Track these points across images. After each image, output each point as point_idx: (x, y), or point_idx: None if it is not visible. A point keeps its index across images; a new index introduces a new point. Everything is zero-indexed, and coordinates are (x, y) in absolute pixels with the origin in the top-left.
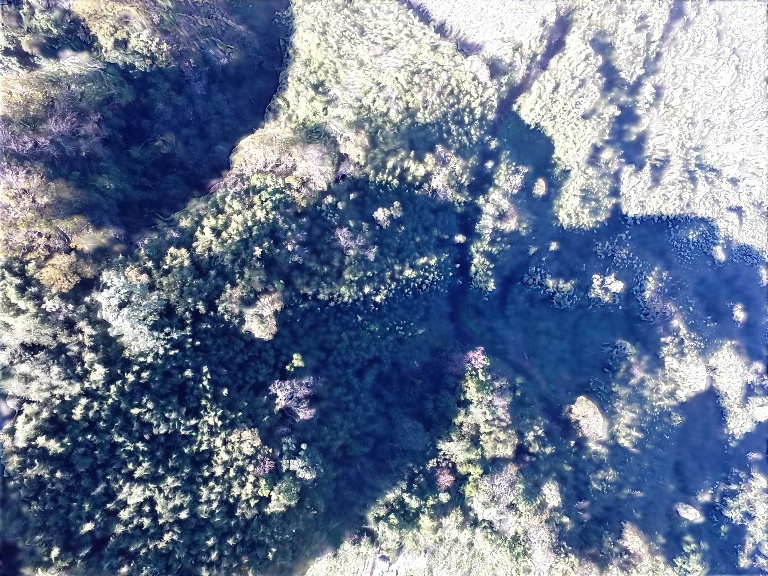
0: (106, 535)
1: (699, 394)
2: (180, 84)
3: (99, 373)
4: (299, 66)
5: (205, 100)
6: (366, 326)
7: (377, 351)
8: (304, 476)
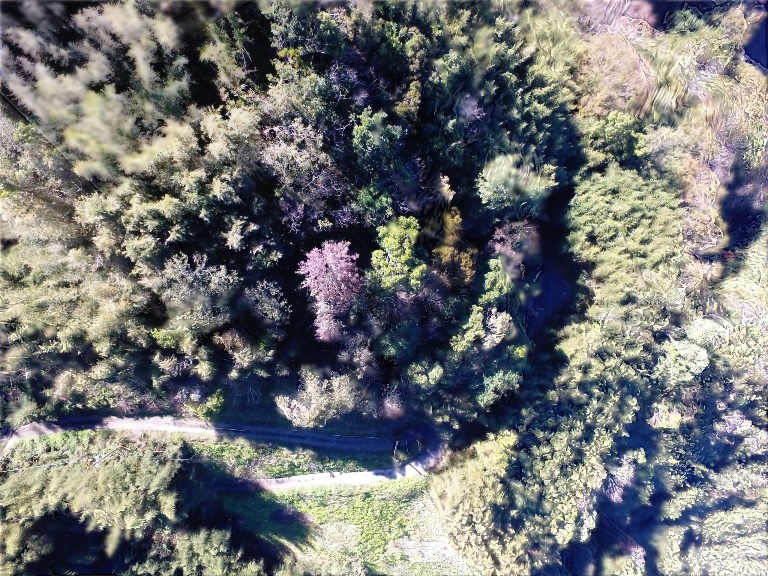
0: (526, 444)
1: None
2: (734, 186)
3: (636, 351)
4: None
5: (727, 210)
6: (651, 468)
7: (632, 487)
8: (583, 535)
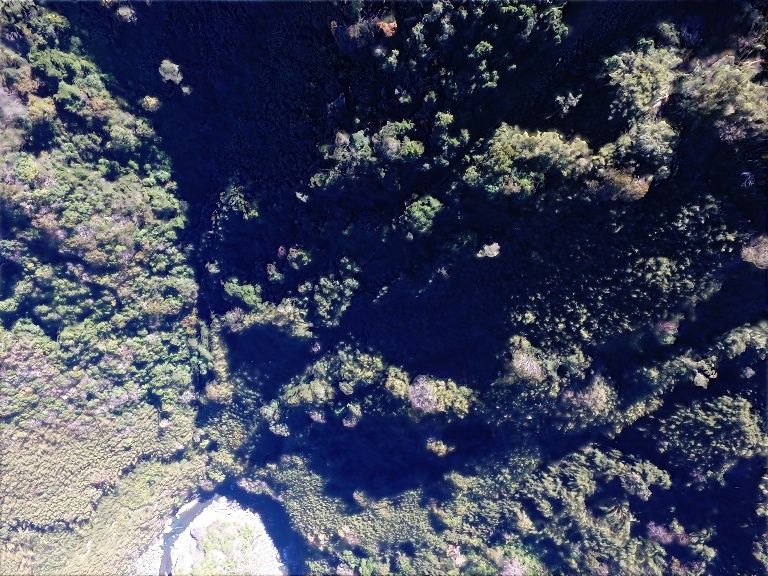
0: None
1: (422, 361)
2: None
3: None
4: None
5: None
6: None
7: None
8: None
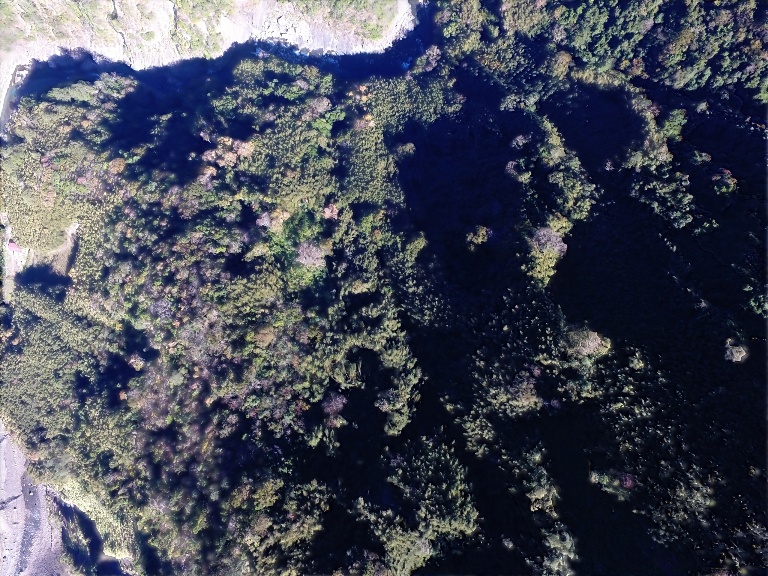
0: None
1: (568, 256)
2: None
3: None
4: None
5: None
6: None
7: None
8: None
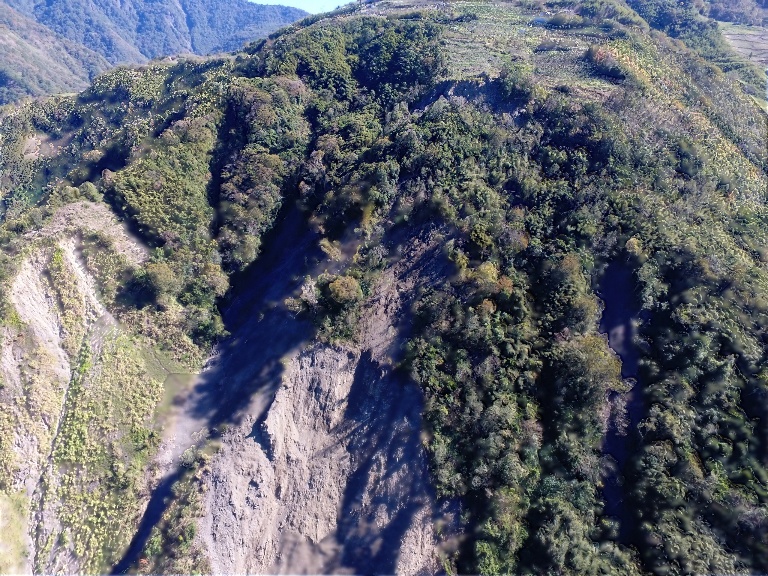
0: None
1: None
2: None
3: None
4: (194, 177)
5: None
6: None
7: None
8: None
